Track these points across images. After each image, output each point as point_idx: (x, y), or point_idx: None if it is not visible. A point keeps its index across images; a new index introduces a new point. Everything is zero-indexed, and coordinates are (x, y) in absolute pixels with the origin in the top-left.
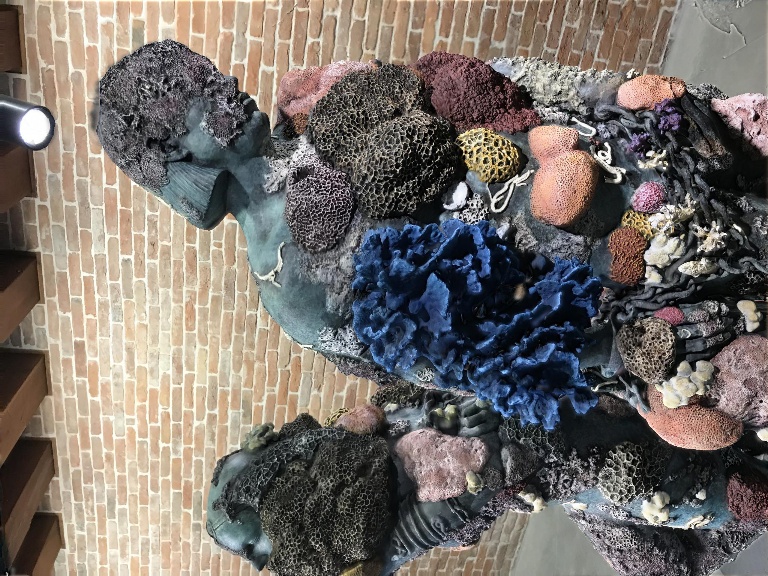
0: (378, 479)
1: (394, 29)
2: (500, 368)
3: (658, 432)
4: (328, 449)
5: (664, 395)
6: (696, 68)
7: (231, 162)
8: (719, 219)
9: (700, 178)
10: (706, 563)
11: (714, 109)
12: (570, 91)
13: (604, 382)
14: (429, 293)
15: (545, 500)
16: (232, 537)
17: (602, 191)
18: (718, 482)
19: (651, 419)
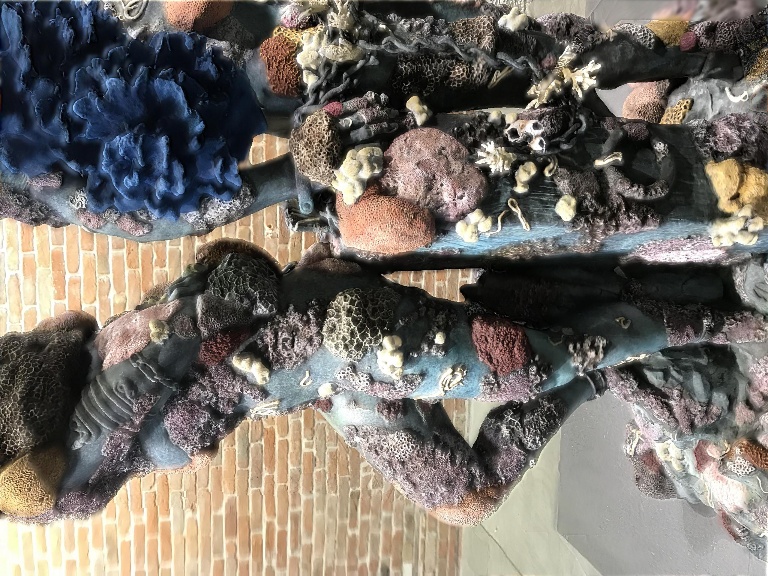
0: (53, 353)
1: None
2: (95, 104)
3: (351, 241)
4: (2, 338)
5: (341, 190)
6: None
7: None
8: (351, 4)
9: None
10: (501, 465)
11: None
12: None
13: (304, 219)
14: (9, 34)
15: (266, 367)
16: None
17: (247, 7)
18: (460, 329)
19: (342, 229)
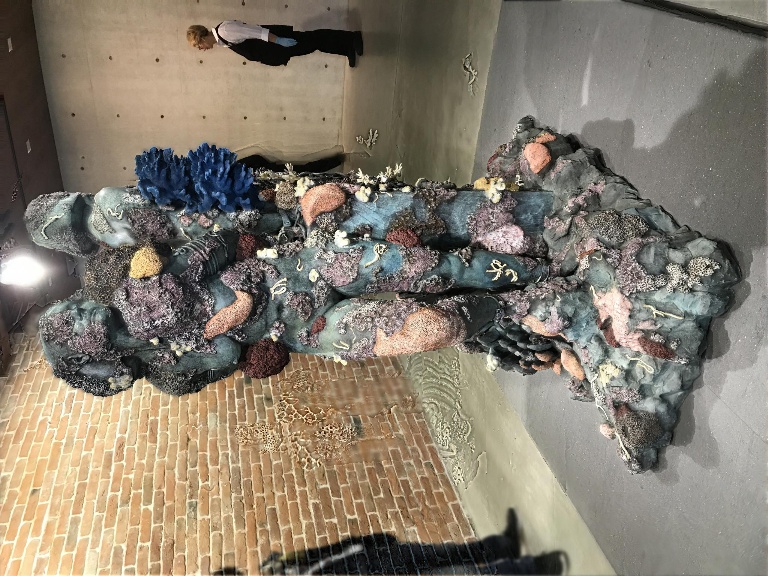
0: None
1: (248, 572)
2: (196, 153)
3: (307, 203)
4: None
5: (299, 193)
6: (485, 502)
7: (88, 202)
8: None
9: None
10: None
11: None
12: None
13: None
14: None
15: None
16: (60, 305)
17: None
18: (379, 240)
19: (302, 204)
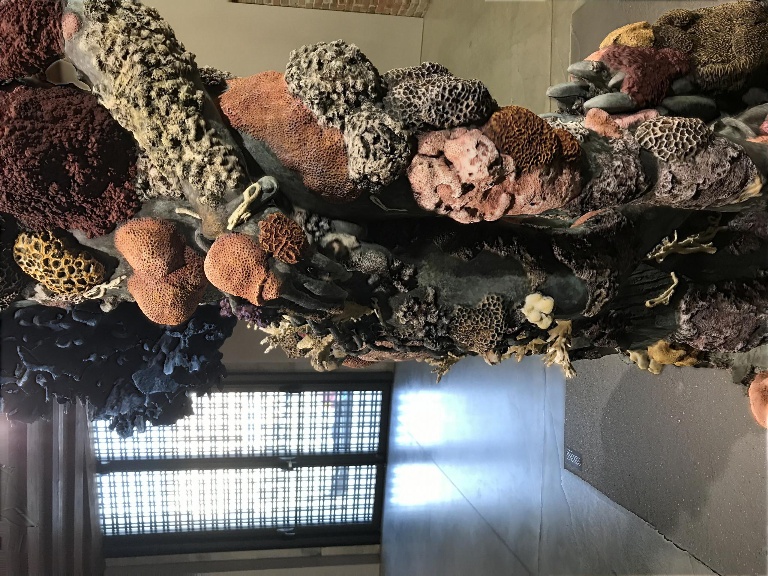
0: None
1: None
2: None
3: None
4: None
5: None
6: None
7: None
8: None
9: (311, 324)
10: None
11: (409, 176)
12: (172, 180)
13: None
14: None
15: None
16: None
17: None
18: None
19: None
